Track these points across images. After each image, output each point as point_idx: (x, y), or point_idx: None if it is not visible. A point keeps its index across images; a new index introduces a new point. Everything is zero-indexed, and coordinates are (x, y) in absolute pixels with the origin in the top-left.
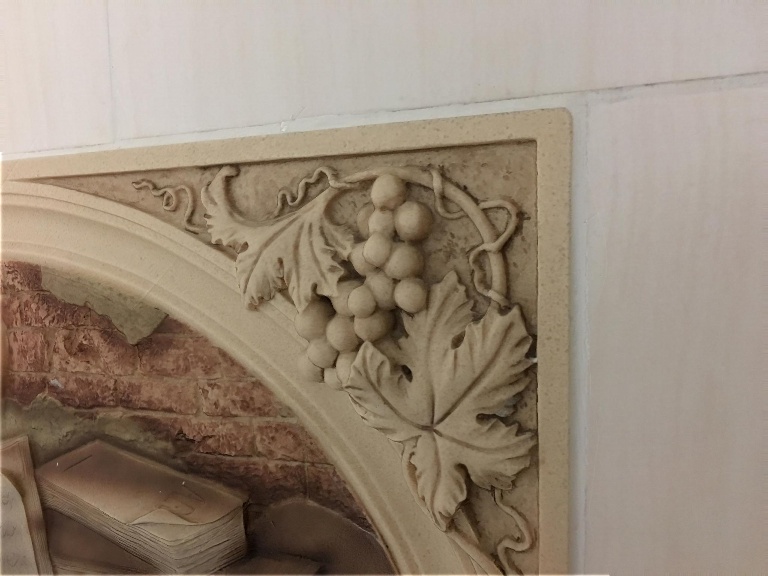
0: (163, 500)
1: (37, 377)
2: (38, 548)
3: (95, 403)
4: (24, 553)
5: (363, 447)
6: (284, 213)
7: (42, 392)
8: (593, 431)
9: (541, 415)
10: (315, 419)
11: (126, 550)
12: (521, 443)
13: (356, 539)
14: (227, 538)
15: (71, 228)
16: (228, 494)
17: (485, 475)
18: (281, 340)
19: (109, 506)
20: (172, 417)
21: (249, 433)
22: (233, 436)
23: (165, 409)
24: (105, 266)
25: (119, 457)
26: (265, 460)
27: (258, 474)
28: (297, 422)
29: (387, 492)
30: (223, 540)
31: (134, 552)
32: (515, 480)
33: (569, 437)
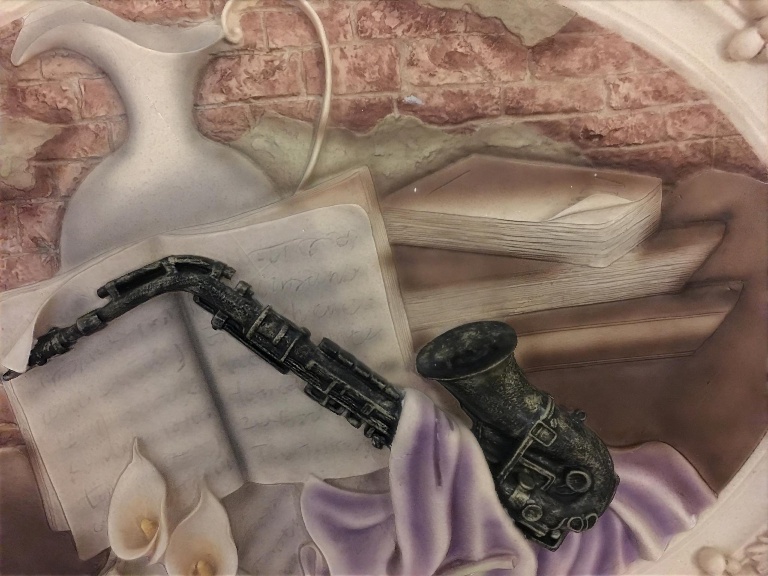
0: (578, 193)
1: (382, 97)
2: (388, 286)
3: (472, 115)
4: (371, 295)
5: (767, 116)
6: None
7: (393, 112)
8: None
9: None
10: (730, 97)
11: (518, 257)
12: None
13: (759, 192)
14: (648, 214)
15: None
16: (646, 176)
17: None
18: (700, 30)
19: (511, 212)
20: (572, 117)
21: (659, 120)
22: (642, 125)
23: (565, 110)
24: None
25: (509, 165)
26: (673, 143)
27: (667, 156)
28: (711, 102)
29: None
30: (645, 216)
31: (534, 255)
32: None
33: None
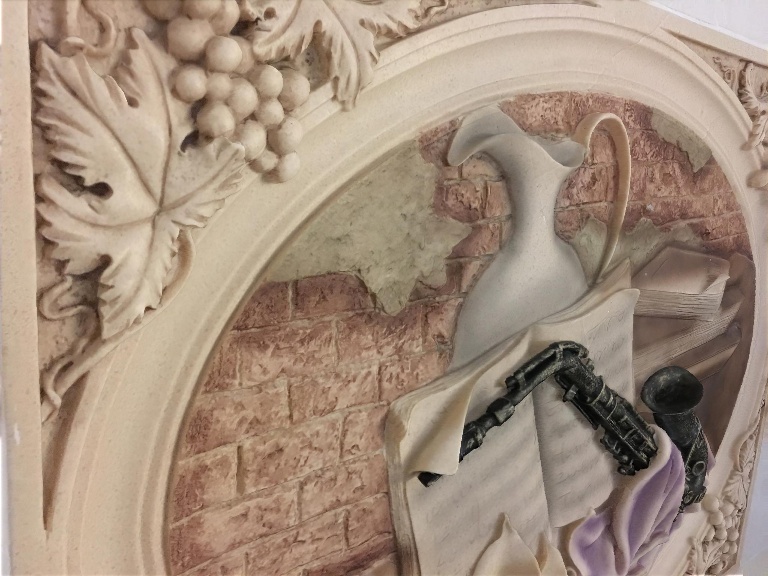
0: (707, 273)
1: None
2: None
3: (670, 219)
4: (627, 357)
5: None
6: (762, 97)
7: None
8: None
9: None
10: None
11: (681, 318)
12: None
13: None
14: None
15: (672, 80)
16: None
17: None
18: (743, 167)
19: None
20: (701, 220)
21: None
22: (721, 226)
23: None
24: (687, 114)
25: None
26: None
27: None
28: None
29: None
30: None
31: None
32: None
33: None
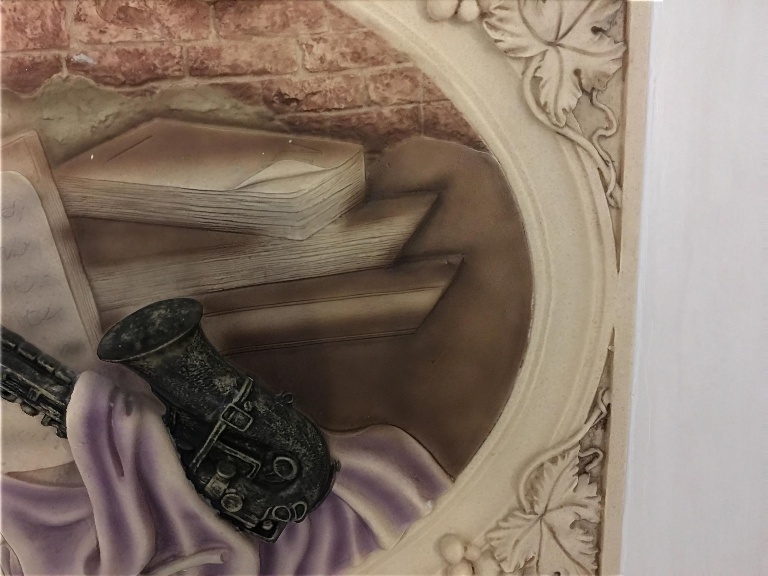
0: (270, 160)
1: (47, 55)
2: (67, 262)
3: (151, 76)
4: (46, 271)
5: (477, 80)
6: None
7: (60, 71)
8: (663, 35)
9: (633, 25)
10: (434, 59)
11: (212, 229)
12: (619, 48)
13: (473, 161)
14: (349, 183)
15: None
16: (345, 142)
17: (594, 76)
18: None
19: (195, 180)
20: (264, 79)
21: (361, 84)
22: (342, 89)
23: (255, 72)
24: None
25: (195, 131)
26: (377, 108)
27: (371, 122)
28: (414, 65)
29: (499, 116)
30: (345, 185)
31: (227, 226)
32: (609, 81)
33: (649, 40)
